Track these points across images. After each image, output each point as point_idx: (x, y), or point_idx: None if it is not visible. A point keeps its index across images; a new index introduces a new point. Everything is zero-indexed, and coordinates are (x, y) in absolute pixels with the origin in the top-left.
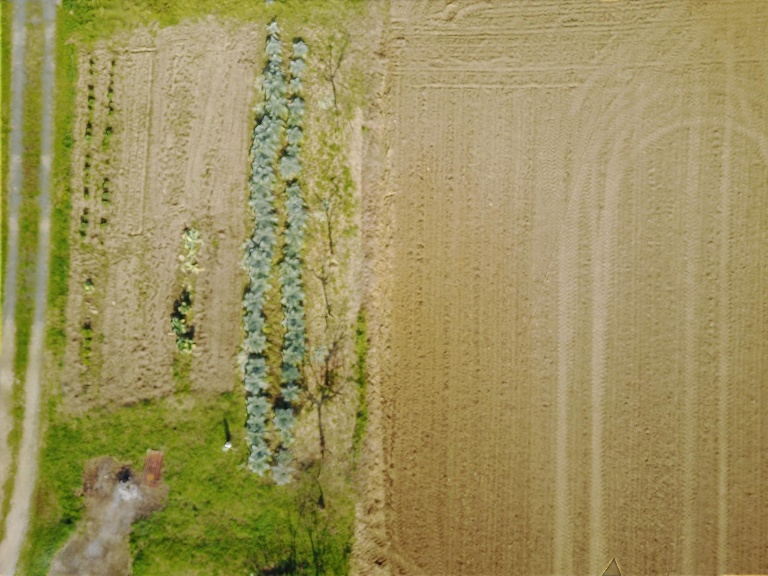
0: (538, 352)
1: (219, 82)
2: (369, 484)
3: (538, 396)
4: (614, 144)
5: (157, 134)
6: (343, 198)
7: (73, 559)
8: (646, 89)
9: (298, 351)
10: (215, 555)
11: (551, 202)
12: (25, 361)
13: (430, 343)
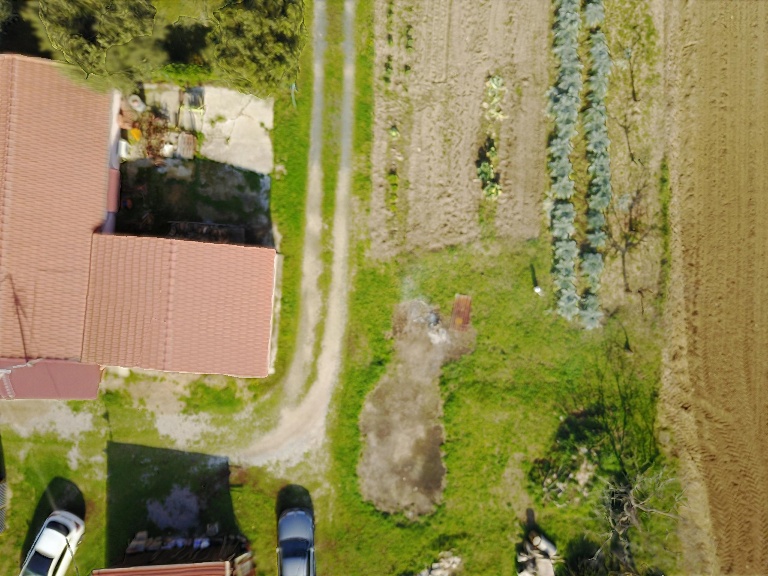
0: None
1: None
2: (673, 331)
3: None
4: None
5: None
6: (645, 46)
7: (383, 401)
8: None
9: (606, 196)
10: (524, 398)
11: None
12: (333, 206)
13: (735, 190)
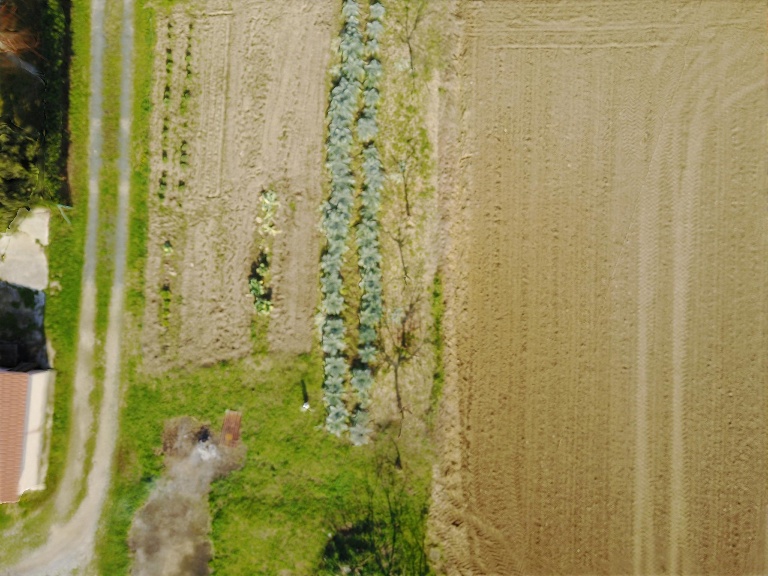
0: (617, 314)
1: (295, 44)
2: (446, 446)
3: (617, 358)
4: (696, 103)
5: (234, 97)
6: (419, 160)
7: (153, 517)
8: (729, 47)
9: (376, 312)
10: (293, 515)
11: (631, 163)
12: (106, 322)
13: (507, 305)
